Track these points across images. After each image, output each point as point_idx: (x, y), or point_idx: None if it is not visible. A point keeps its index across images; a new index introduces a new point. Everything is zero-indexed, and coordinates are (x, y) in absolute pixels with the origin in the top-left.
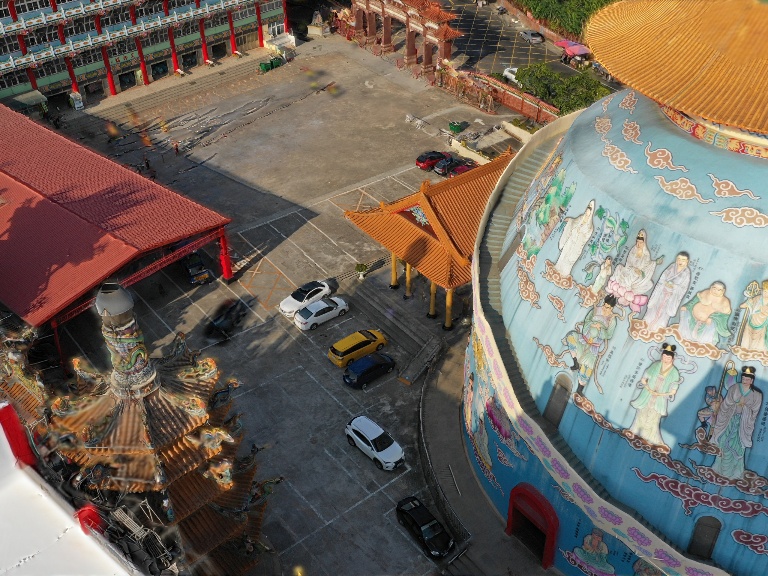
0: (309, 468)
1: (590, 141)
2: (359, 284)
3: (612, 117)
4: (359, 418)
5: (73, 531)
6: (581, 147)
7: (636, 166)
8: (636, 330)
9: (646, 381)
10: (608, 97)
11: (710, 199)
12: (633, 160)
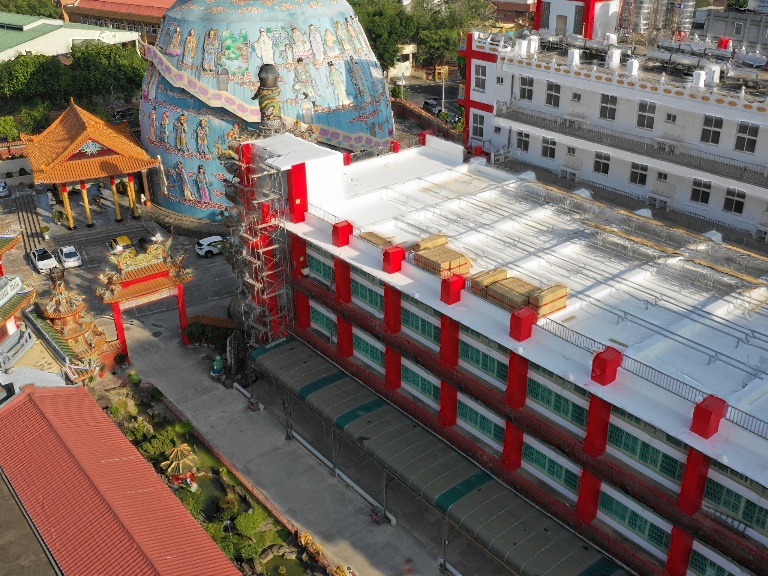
0: (218, 271)
1: (223, 15)
2: (53, 241)
3: (216, 6)
4: (201, 241)
5: (344, 169)
6: (223, 19)
7: (263, 8)
8: (317, 64)
9: (333, 80)
10: (187, 9)
11: (300, 5)
12: (259, 7)
